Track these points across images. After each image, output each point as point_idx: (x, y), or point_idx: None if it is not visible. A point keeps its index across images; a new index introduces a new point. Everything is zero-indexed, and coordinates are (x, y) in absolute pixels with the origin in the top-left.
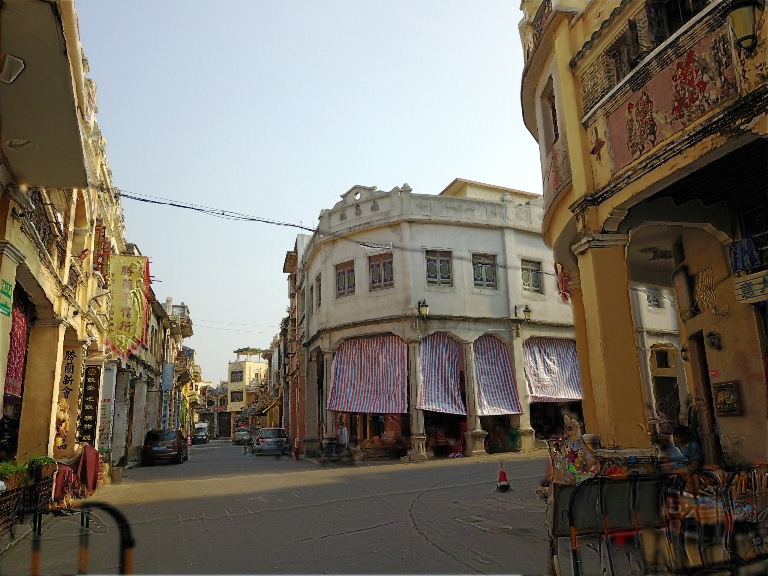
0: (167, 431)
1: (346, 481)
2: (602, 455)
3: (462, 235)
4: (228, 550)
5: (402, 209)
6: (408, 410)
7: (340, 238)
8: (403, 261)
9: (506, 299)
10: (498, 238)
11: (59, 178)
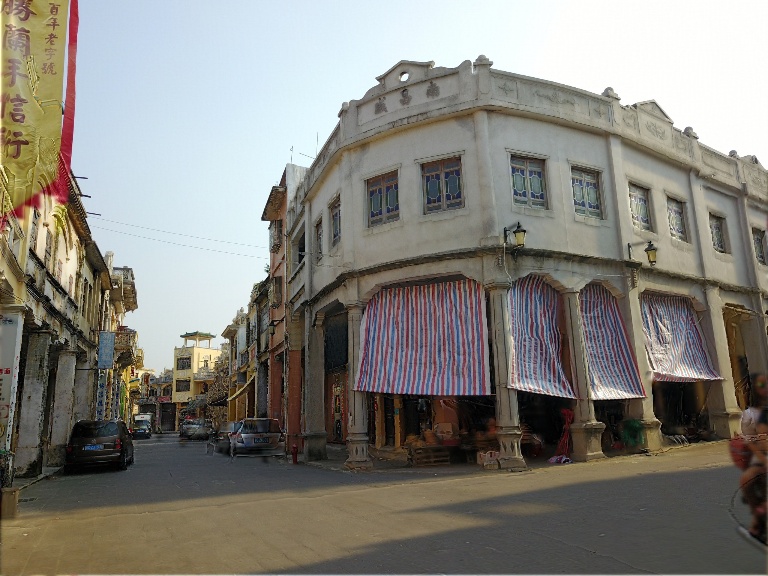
0: (105, 423)
1: (501, 525)
2: None
3: (558, 138)
4: None
5: (478, 91)
6: (492, 390)
7: (375, 140)
8: (479, 168)
9: (616, 234)
10: (602, 148)
11: None
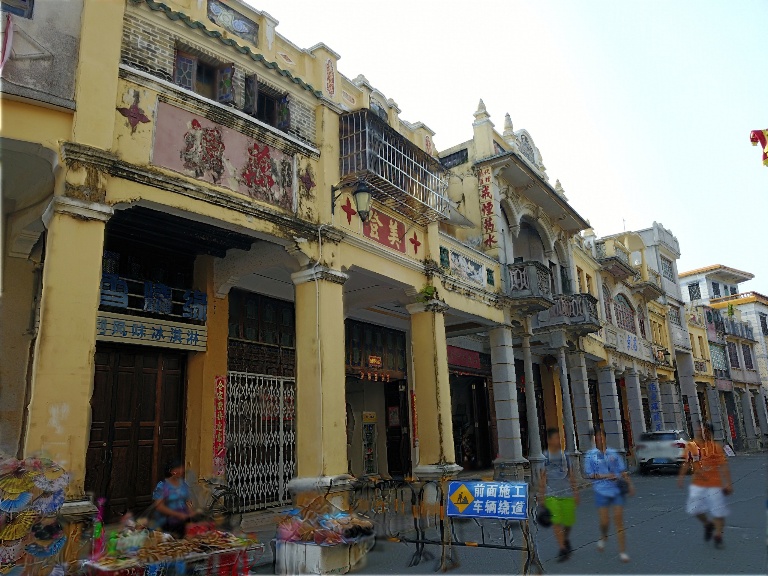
0: None
1: None
2: (74, 511)
3: None
4: None
5: None
6: None
7: None
8: None
9: None
10: None
11: None
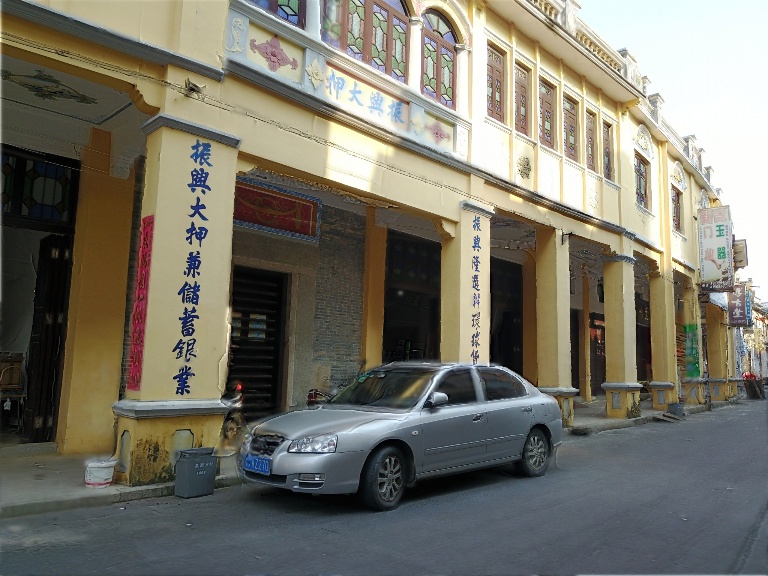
0: None
1: None
2: None
3: None
4: None
5: None
6: None
7: None
8: None
9: None
10: None
11: (749, 333)
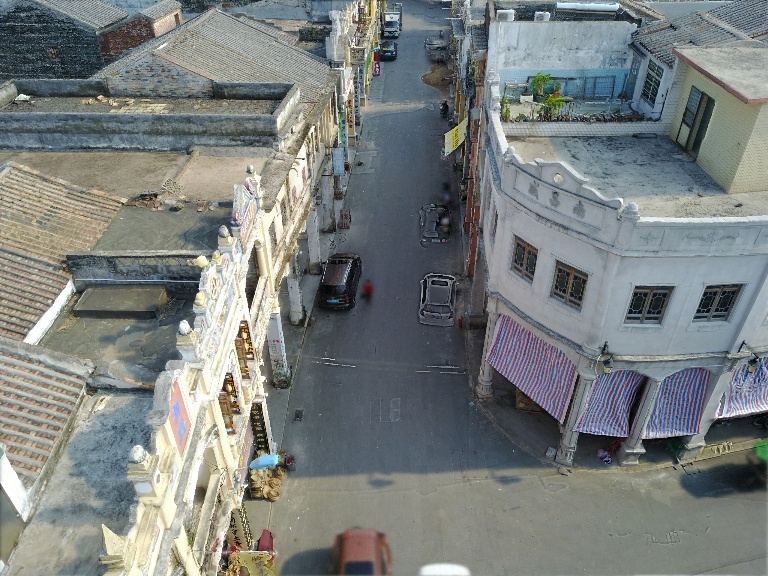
0: (338, 280)
1: None
2: None
3: (701, 265)
4: None
5: (616, 240)
6: (564, 423)
7: None
8: (599, 294)
9: (734, 333)
10: (761, 262)
11: None
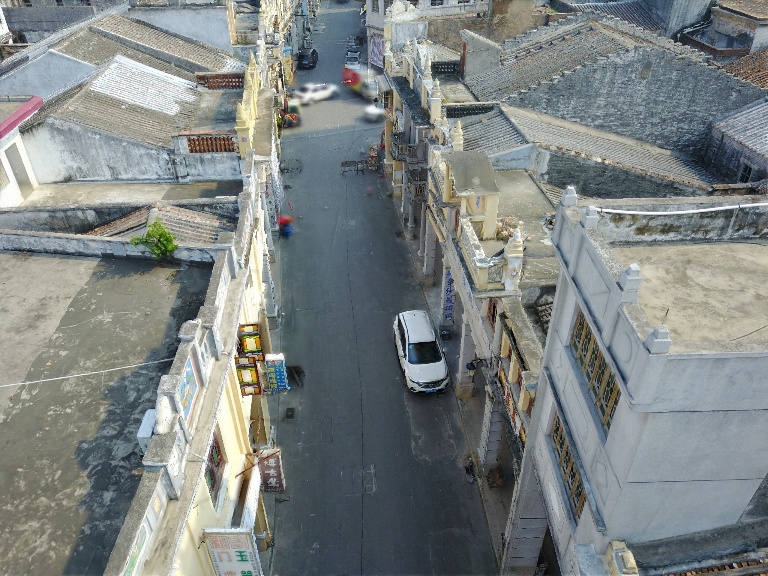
0: (307, 53)
1: (356, 116)
2: None
3: None
4: (315, 152)
5: None
6: None
7: None
8: None
9: None
10: None
11: None
